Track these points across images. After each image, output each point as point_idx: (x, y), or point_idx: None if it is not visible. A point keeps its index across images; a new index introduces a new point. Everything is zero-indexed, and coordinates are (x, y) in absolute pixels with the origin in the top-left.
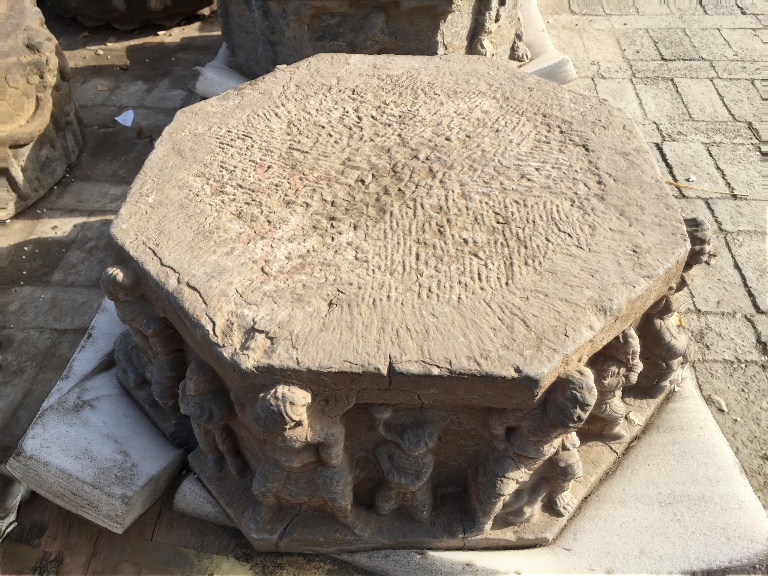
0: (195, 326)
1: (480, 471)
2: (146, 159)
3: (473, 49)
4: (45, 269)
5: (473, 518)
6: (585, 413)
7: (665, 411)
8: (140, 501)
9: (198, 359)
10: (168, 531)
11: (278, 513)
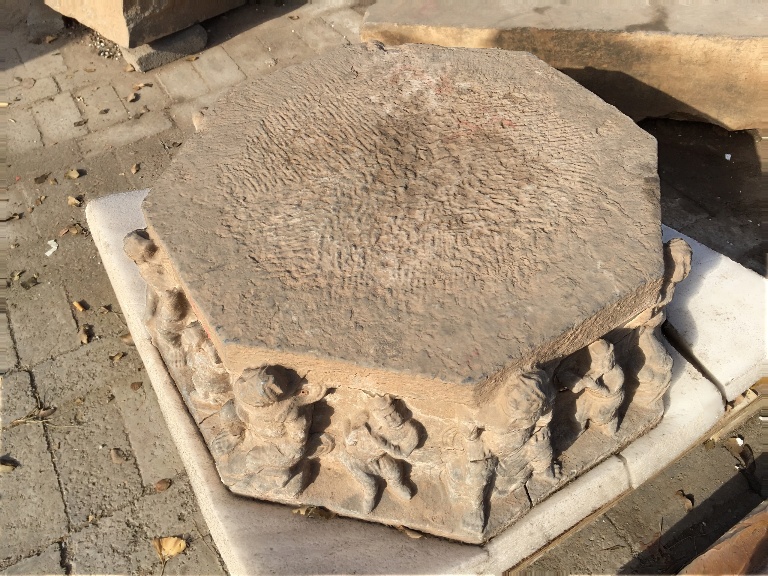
0: None
1: None
2: None
3: None
4: None
5: None
6: None
7: None
8: None
9: None
10: None
11: None
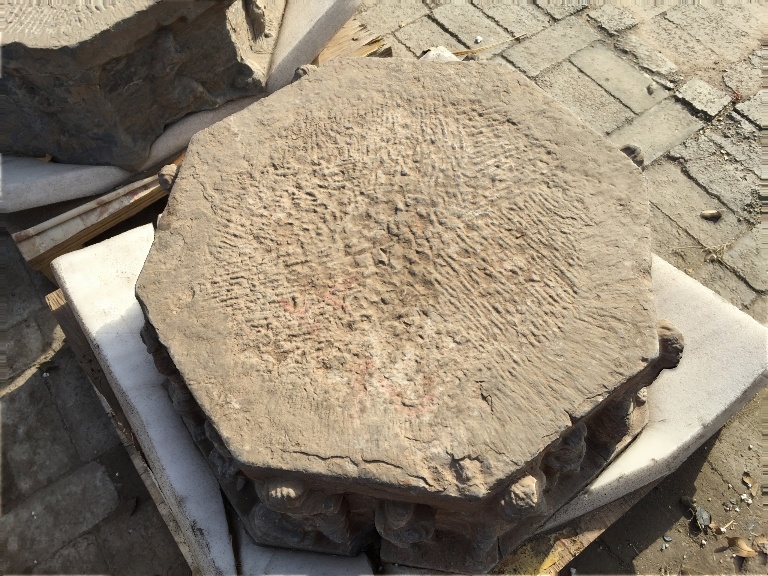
0: (408, 490)
1: (605, 420)
2: (175, 365)
3: (251, 14)
4: (1, 486)
5: (605, 447)
6: None
7: None
8: None
9: (397, 503)
10: None
11: None
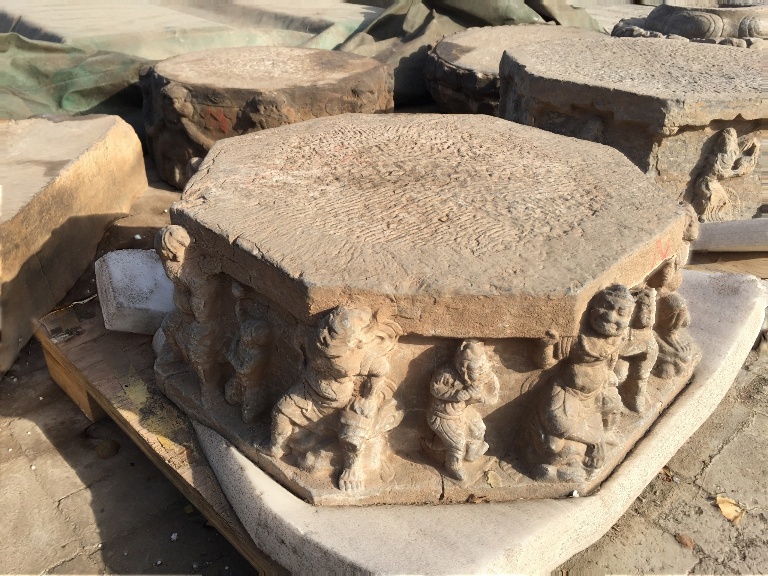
0: None
1: None
2: None
3: (696, 187)
4: None
5: None
6: (332, 339)
7: (537, 499)
8: (131, 319)
9: None
10: (137, 354)
11: (179, 364)
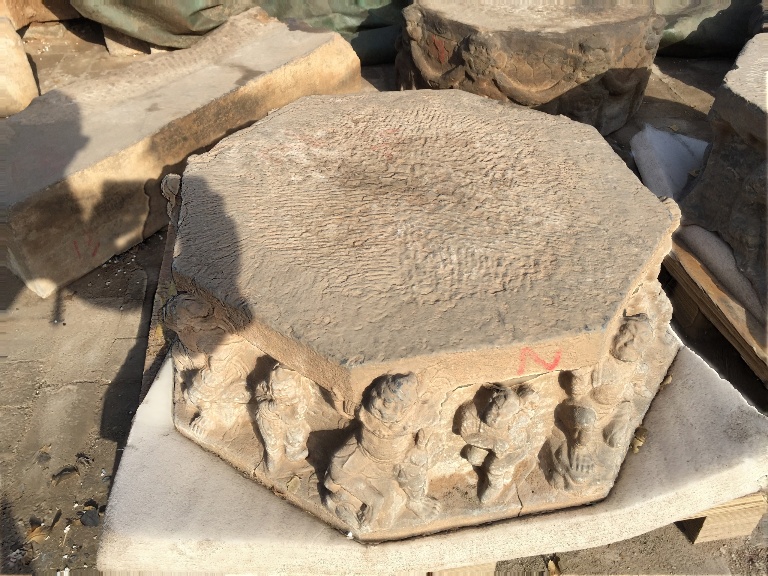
0: None
1: None
2: None
3: None
4: None
5: None
6: None
7: (315, 520)
8: None
9: None
10: None
11: None
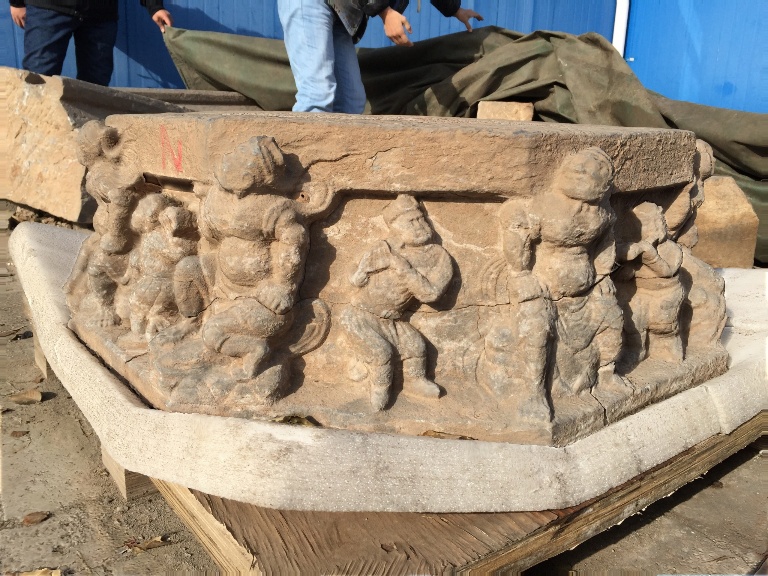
0: None
1: None
2: None
3: None
4: None
5: None
6: None
7: None
8: None
9: None
10: None
11: None
